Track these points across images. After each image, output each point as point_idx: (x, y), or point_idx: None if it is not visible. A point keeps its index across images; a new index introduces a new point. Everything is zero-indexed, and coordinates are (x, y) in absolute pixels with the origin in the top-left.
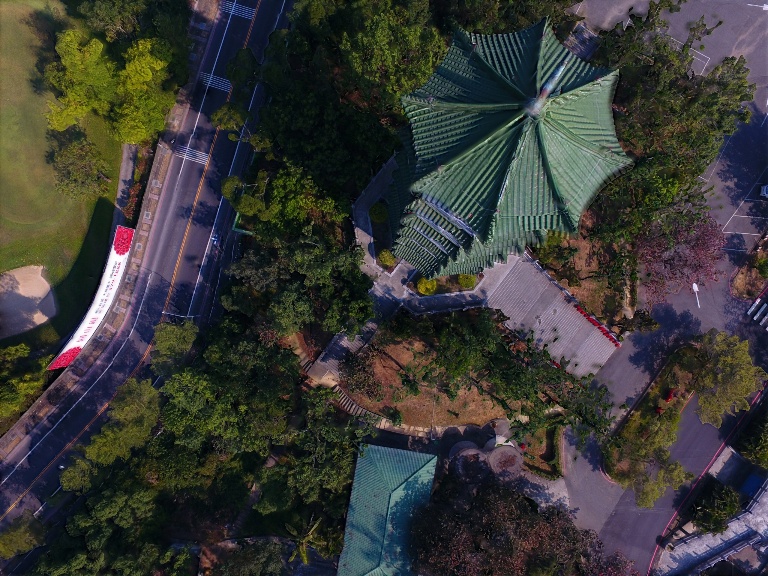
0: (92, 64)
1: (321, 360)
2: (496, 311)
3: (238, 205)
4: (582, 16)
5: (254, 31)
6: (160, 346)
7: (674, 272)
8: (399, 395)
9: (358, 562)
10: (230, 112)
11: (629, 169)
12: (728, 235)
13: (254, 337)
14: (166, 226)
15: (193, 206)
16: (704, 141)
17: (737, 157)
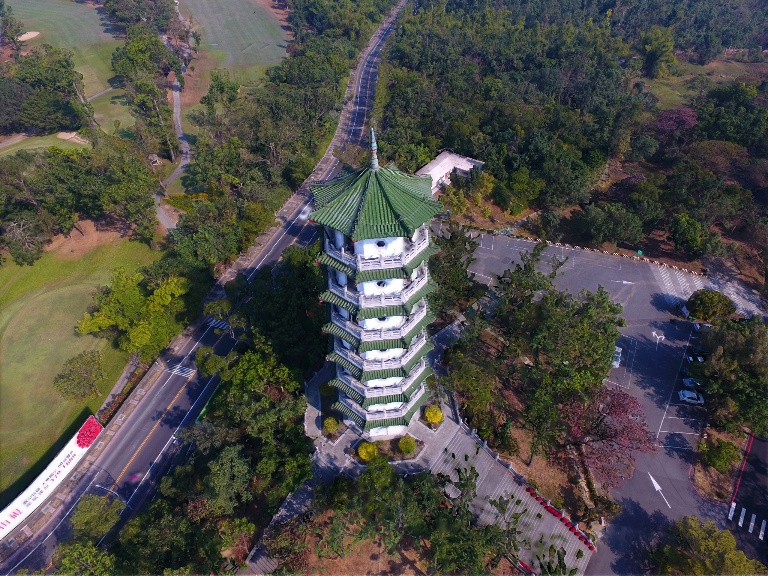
0: (131, 288)
1: (250, 560)
2: (438, 476)
3: (205, 362)
4: None
5: None
6: (78, 517)
7: (610, 443)
8: (324, 544)
9: None
10: (219, 302)
11: (441, 207)
12: (667, 434)
13: (182, 515)
14: (134, 427)
15: (166, 410)
16: (596, 339)
17: (646, 371)
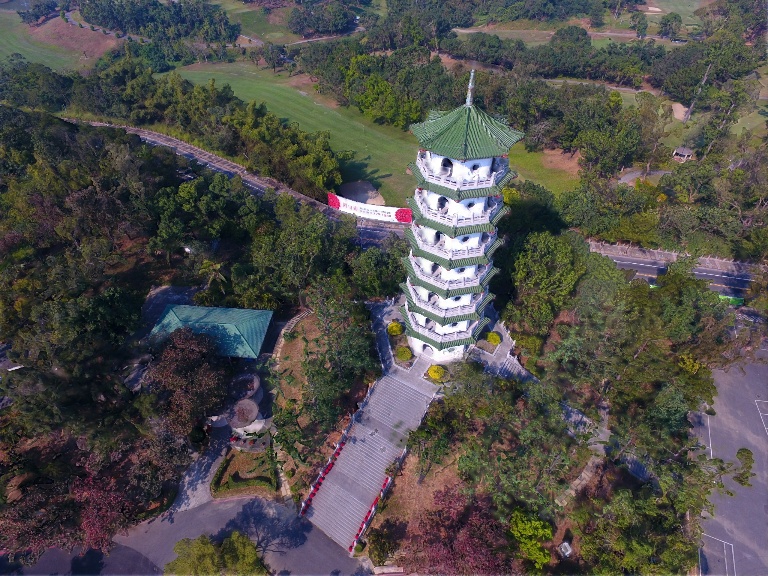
0: None
1: None
2: None
3: None
4: None
5: None
6: (343, 215)
7: None
8: (314, 292)
9: (186, 313)
10: None
11: None
12: None
13: None
14: None
15: None
16: (601, 569)
17: None
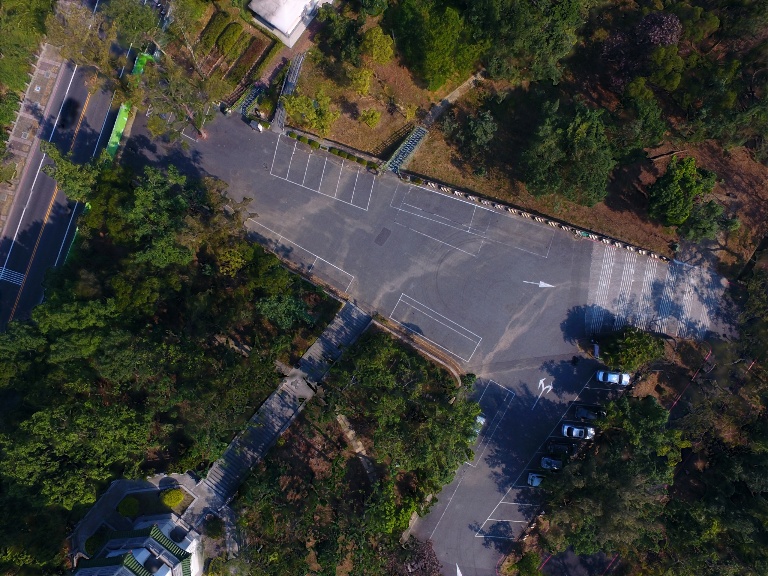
0: None
1: None
2: None
3: None
4: (353, 293)
5: (23, 297)
6: None
7: None
8: None
9: None
10: None
11: None
12: (494, 523)
13: None
14: None
15: None
16: (430, 476)
17: (506, 442)
